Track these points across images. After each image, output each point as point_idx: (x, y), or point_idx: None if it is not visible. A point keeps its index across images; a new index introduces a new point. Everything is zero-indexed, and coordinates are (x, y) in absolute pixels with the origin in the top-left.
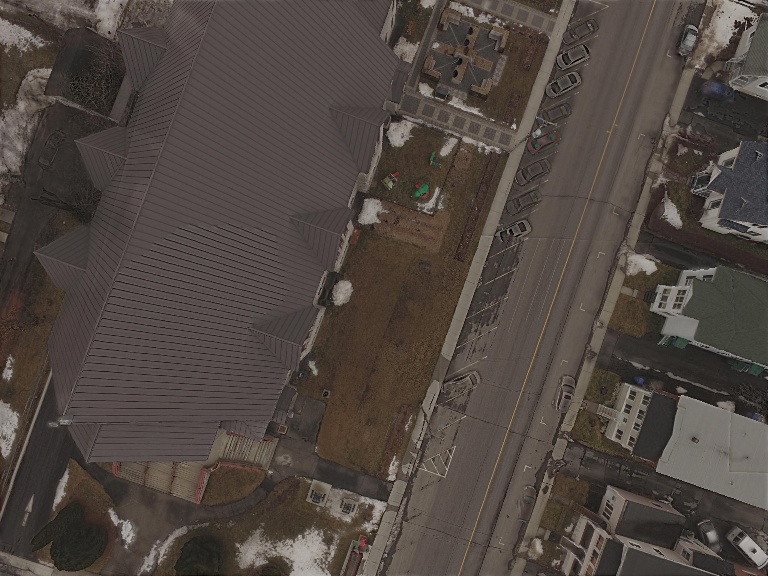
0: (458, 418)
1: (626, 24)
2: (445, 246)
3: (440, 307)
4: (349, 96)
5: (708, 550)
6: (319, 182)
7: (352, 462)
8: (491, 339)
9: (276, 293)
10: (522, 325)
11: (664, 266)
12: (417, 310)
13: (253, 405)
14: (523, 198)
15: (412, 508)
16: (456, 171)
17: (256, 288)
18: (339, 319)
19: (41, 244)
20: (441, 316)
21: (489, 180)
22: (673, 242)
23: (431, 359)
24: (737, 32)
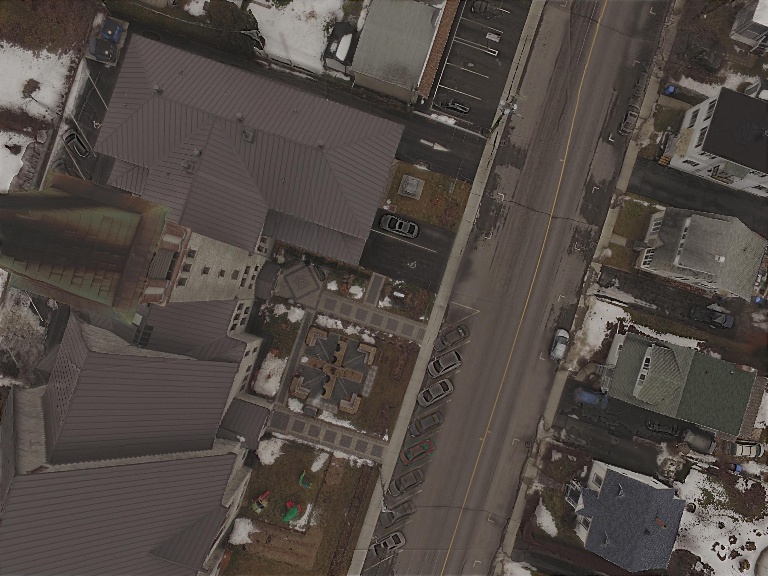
0: None
1: (497, 329)
2: (318, 563)
3: None
4: (173, 527)
5: None
6: None
7: None
8: None
9: None
10: None
11: (540, 575)
12: None
13: None
14: (397, 509)
15: None
16: (328, 486)
17: None
18: None
19: None
20: None
21: (361, 494)
22: None
23: None
24: (609, 334)
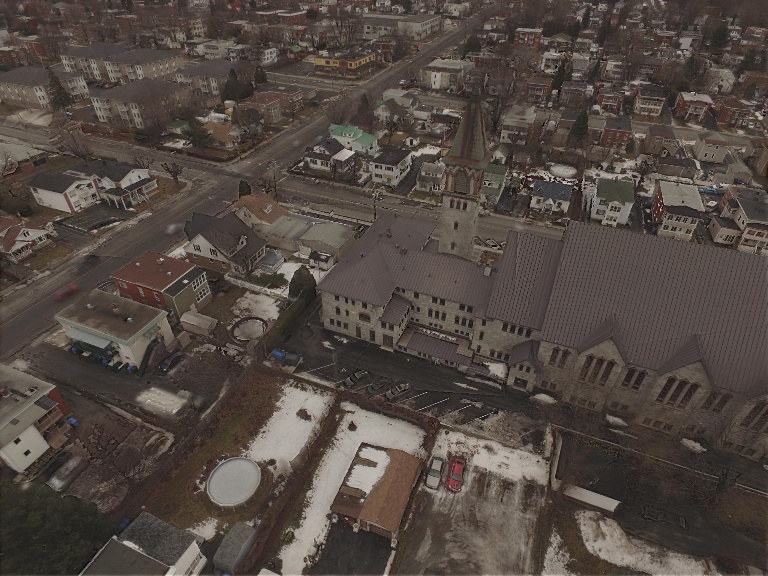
0: None
1: None
2: None
3: None
4: None
5: (724, 211)
6: None
7: None
8: None
9: None
10: None
11: None
12: None
13: None
14: None
15: None
16: None
17: None
18: None
19: (765, 540)
20: None
21: None
22: None
23: None
24: None
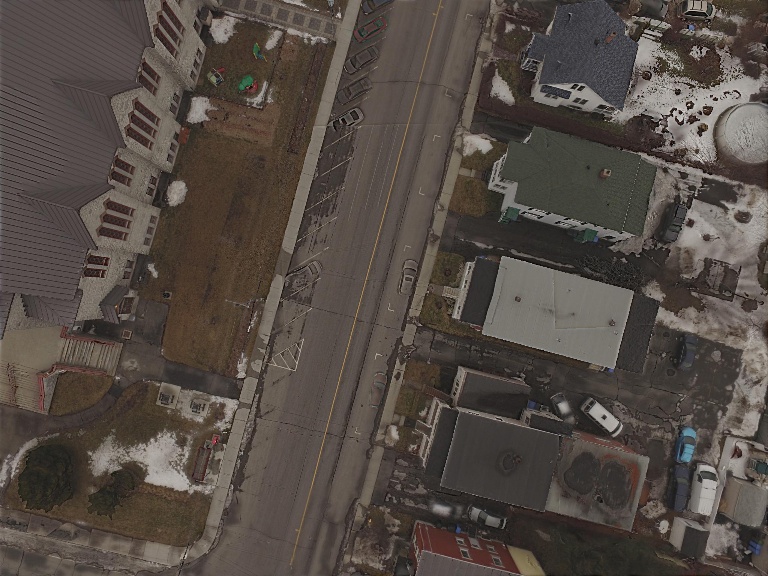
0: (304, 311)
1: None
2: (277, 139)
3: (277, 201)
4: None
5: (554, 417)
6: (88, 48)
7: (200, 362)
8: (331, 229)
9: (51, 162)
10: (361, 213)
11: (499, 144)
12: (254, 205)
13: (43, 280)
14: (353, 86)
15: (265, 404)
16: (283, 64)
17: (20, 152)
18: (175, 220)
19: None
20: (279, 210)
21: (317, 70)
22: (507, 119)
23: (272, 253)
24: None
